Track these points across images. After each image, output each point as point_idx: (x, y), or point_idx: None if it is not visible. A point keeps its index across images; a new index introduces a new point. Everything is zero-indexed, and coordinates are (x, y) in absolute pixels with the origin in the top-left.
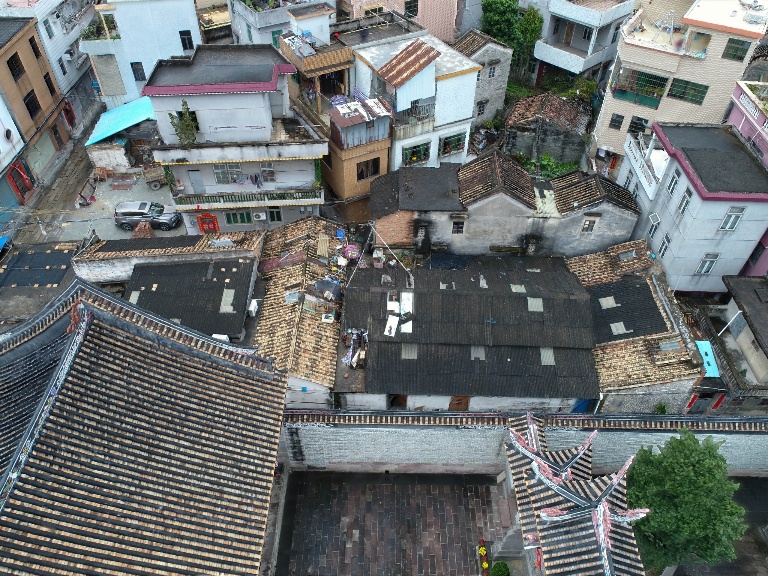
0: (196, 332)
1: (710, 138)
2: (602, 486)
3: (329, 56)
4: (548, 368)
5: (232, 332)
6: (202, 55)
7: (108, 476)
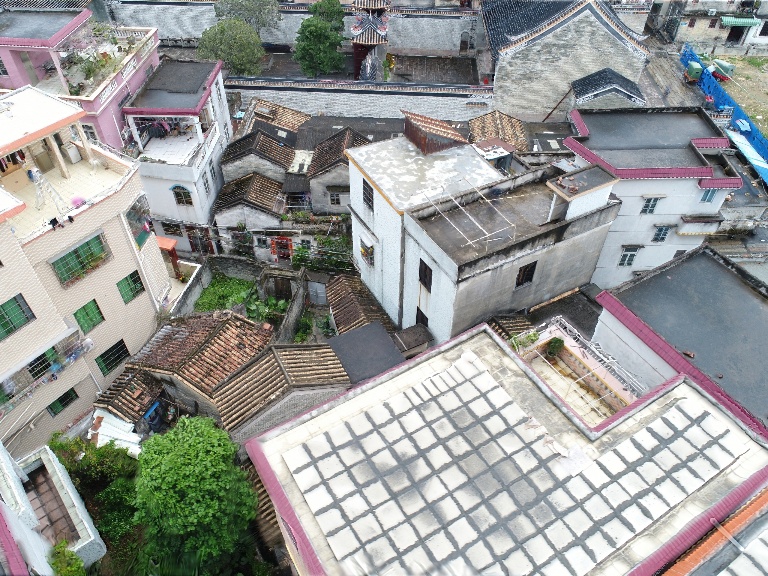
0: (537, 25)
1: (159, 101)
2: (363, 1)
3: (536, 171)
4: (339, 120)
5: (542, 134)
6: (695, 165)
7: (545, 5)
